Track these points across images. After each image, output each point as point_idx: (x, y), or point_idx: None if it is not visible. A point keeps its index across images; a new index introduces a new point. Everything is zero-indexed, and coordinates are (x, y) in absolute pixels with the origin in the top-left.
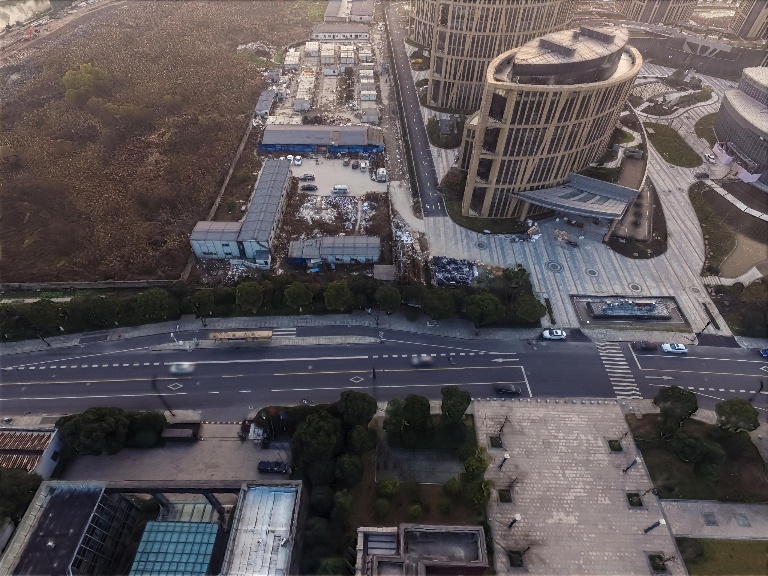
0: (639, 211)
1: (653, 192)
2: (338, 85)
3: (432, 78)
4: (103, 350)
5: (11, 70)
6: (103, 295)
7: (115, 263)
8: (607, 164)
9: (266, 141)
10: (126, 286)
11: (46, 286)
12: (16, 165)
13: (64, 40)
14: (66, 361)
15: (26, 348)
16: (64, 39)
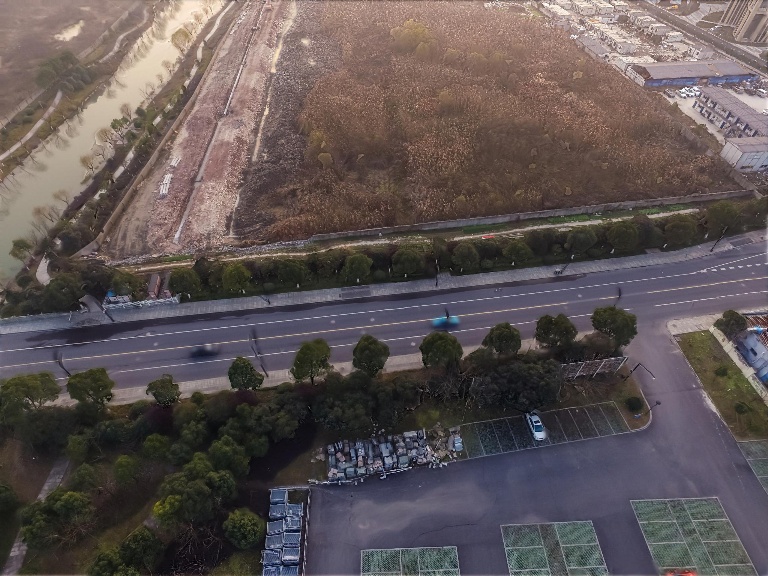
0: None
1: None
2: (627, 31)
3: (756, 13)
4: (762, 250)
5: (296, 36)
6: (694, 208)
7: (677, 181)
8: None
9: (656, 76)
10: (707, 199)
11: (640, 204)
12: (448, 111)
13: (310, 8)
14: (744, 261)
15: (693, 254)
16: (308, 7)
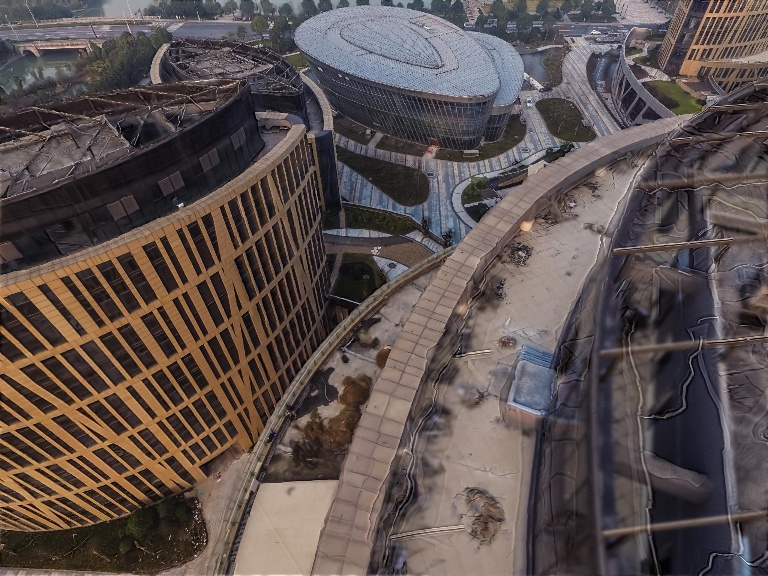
0: (607, 68)
1: (593, 80)
2: None
3: None
4: None
5: None
6: None
7: None
8: (657, 43)
9: None
10: None
11: None
12: None
13: None
14: None
15: None
16: None
